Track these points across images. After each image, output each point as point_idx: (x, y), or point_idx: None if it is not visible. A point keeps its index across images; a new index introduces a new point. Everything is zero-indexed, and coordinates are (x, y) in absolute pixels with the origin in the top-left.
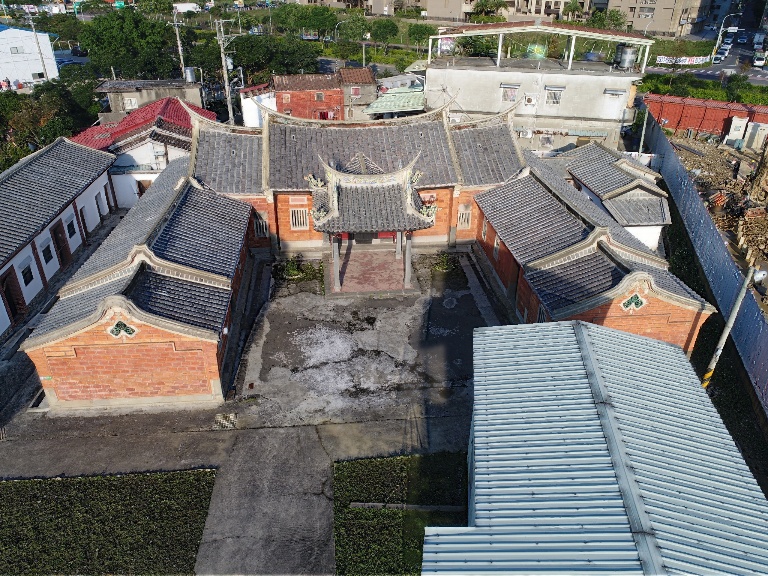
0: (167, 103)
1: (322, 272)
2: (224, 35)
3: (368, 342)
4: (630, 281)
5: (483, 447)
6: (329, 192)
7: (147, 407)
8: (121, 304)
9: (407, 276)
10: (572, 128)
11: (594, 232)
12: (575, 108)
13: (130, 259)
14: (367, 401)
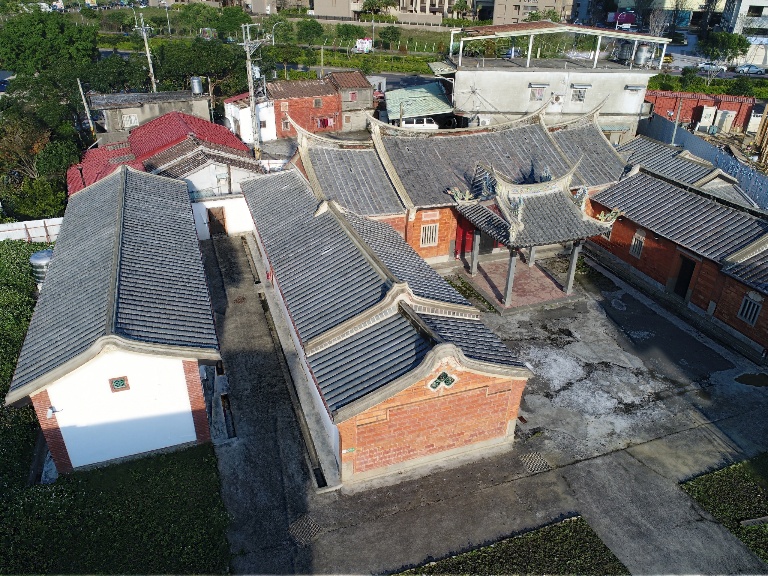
0: (181, 118)
1: (470, 288)
2: (250, 41)
3: (587, 355)
4: None
5: None
6: (501, 205)
7: (442, 462)
8: (453, 353)
9: (570, 283)
10: None
11: None
12: None
13: (389, 300)
14: (645, 415)
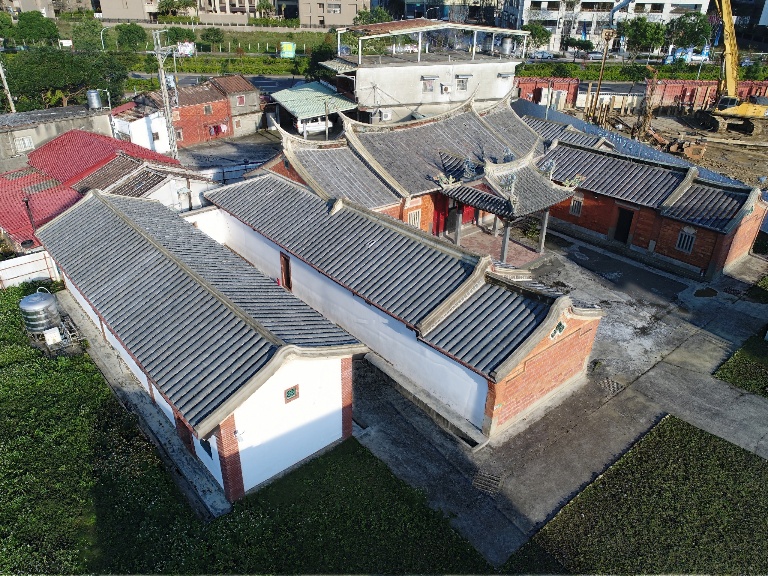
0: (89, 136)
1: None
2: (161, 48)
3: (588, 298)
4: (756, 195)
5: None
6: (491, 183)
7: (548, 403)
8: None
9: (542, 244)
10: (477, 109)
11: (691, 172)
12: (478, 92)
13: (479, 273)
14: (658, 333)
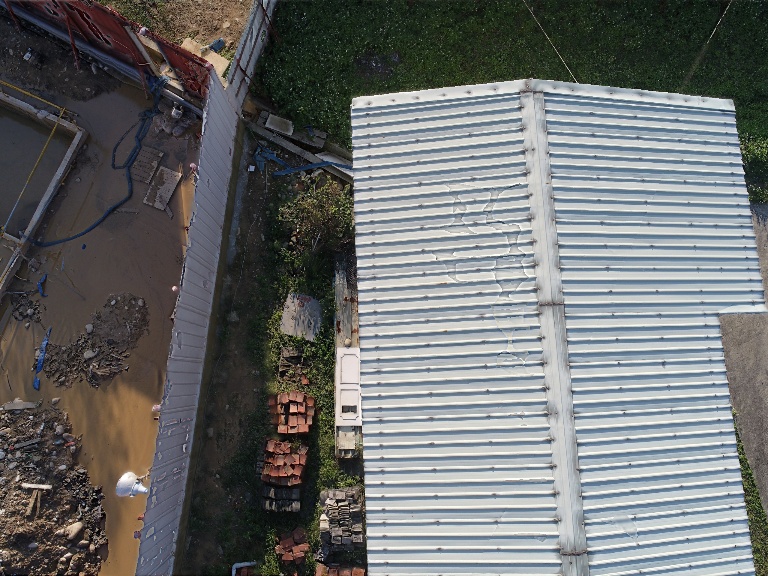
0: None
1: None
2: None
3: None
4: None
5: (728, 449)
6: None
7: None
8: None
9: None
10: None
11: None
12: None
13: None
14: None
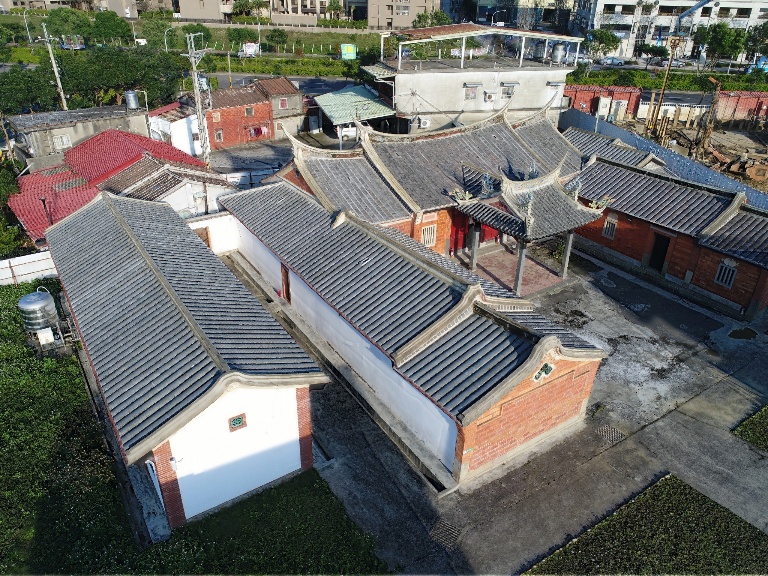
0: (123, 136)
1: None
2: (195, 51)
3: (605, 331)
4: None
5: None
6: (508, 202)
7: (535, 448)
8: (555, 344)
9: (565, 268)
10: None
11: (738, 197)
12: (525, 100)
13: (466, 302)
14: (677, 377)
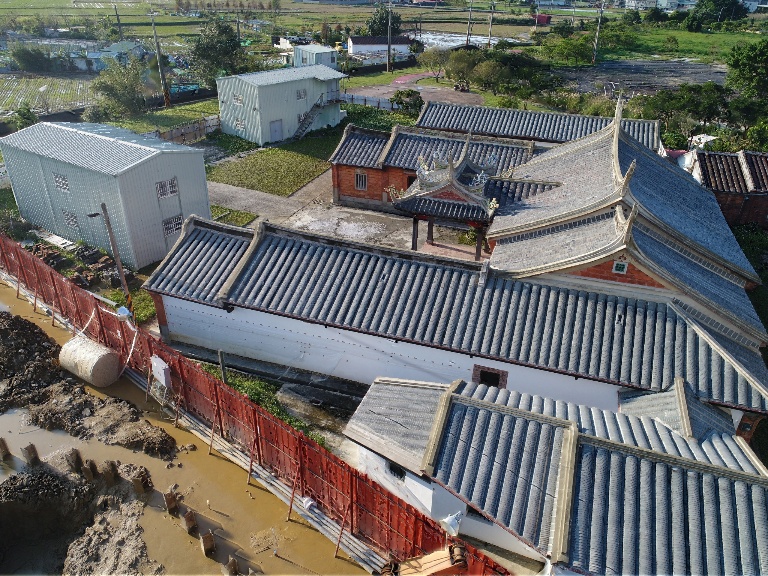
0: None
1: None
2: None
3: None
4: None
5: None
6: None
7: None
8: None
9: None
10: None
11: None
12: None
13: None
14: None
